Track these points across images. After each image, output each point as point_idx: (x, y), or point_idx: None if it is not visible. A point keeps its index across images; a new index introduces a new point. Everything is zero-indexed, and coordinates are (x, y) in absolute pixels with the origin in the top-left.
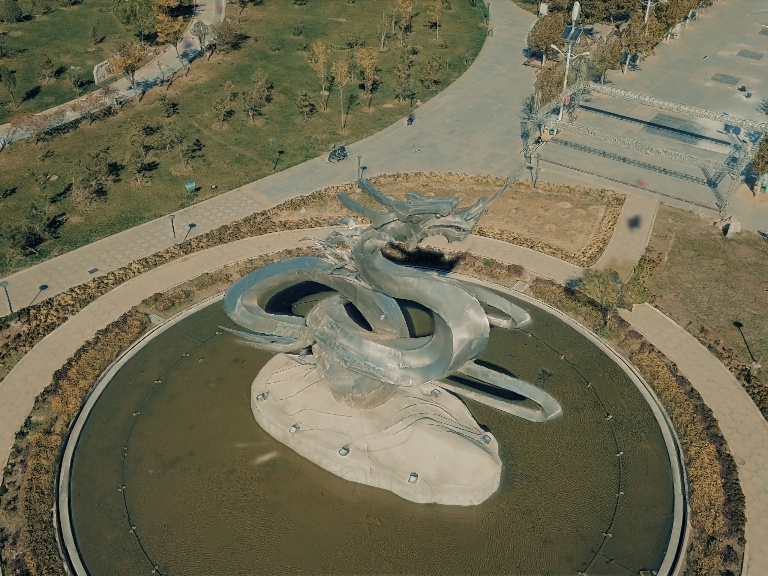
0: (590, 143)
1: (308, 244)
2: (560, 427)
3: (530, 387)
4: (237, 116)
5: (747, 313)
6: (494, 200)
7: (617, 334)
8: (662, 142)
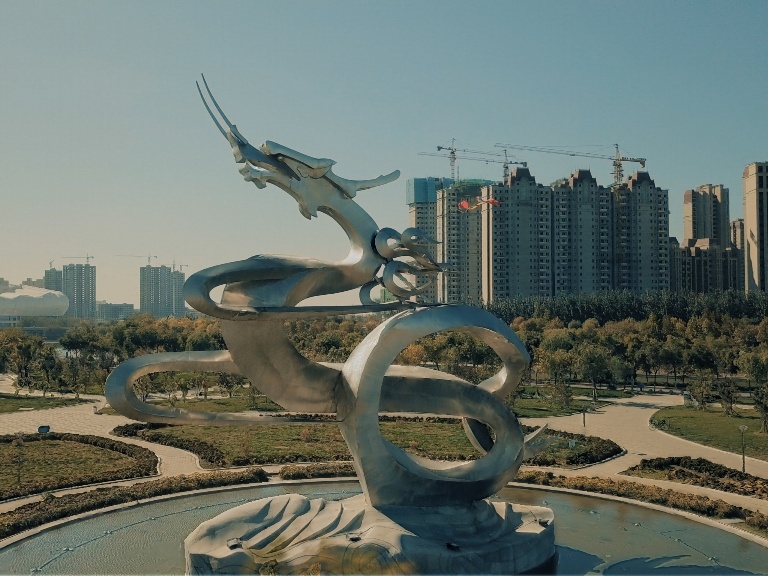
0: None
1: None
2: None
3: None
4: None
5: None
6: None
7: None
8: None
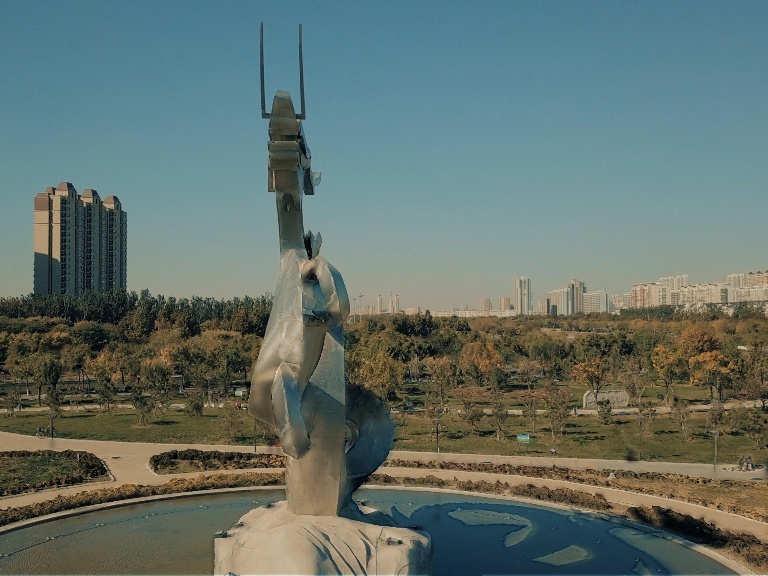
0: None
1: None
2: None
3: None
4: None
5: None
6: None
7: None
8: None
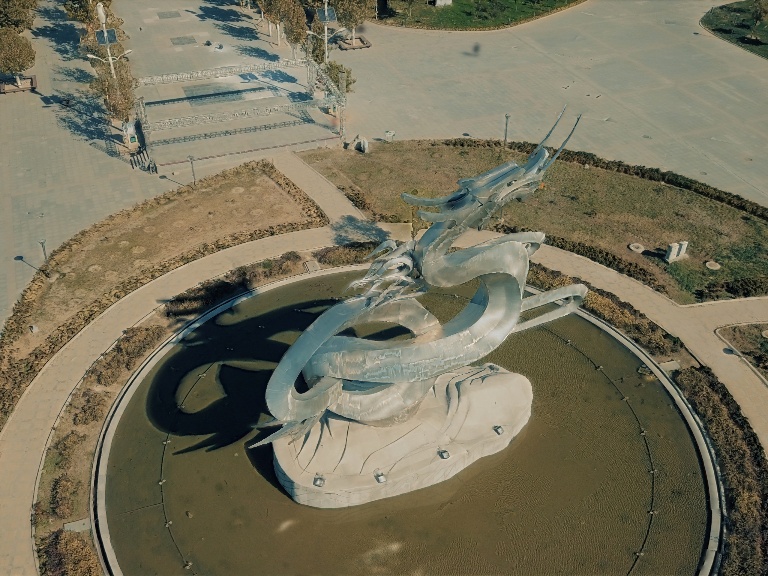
0: (183, 133)
1: (97, 353)
2: None
3: (570, 287)
4: None
5: (449, 193)
6: (182, 217)
7: None
8: (230, 107)
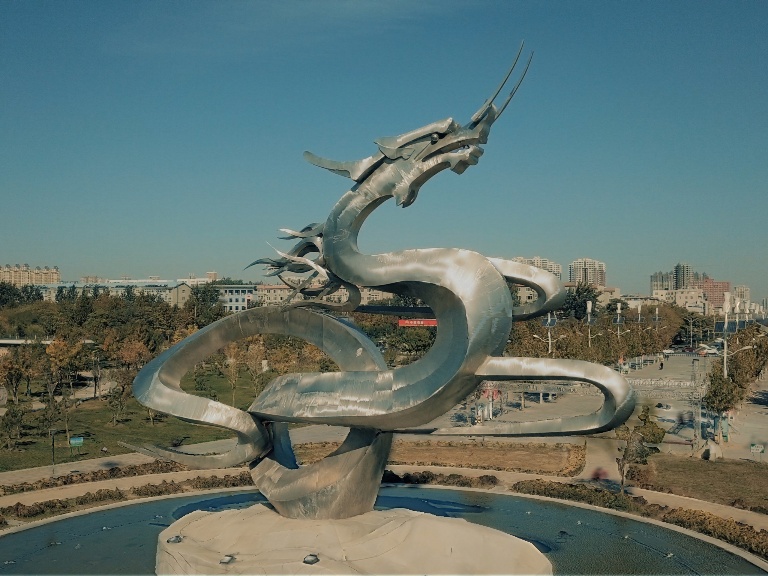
0: None
1: None
2: (609, 568)
3: (583, 363)
4: (134, 421)
5: None
6: (441, 453)
7: (636, 505)
8: None
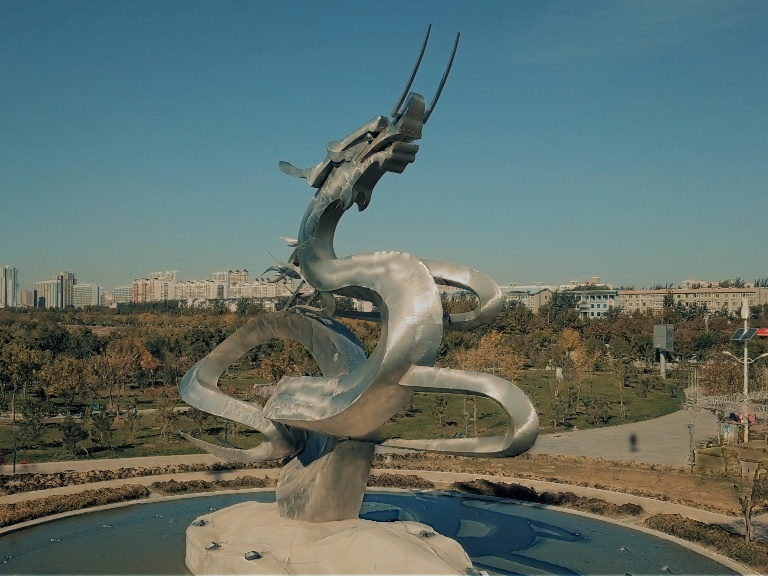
0: None
1: None
2: None
3: (487, 376)
4: None
5: None
6: (631, 475)
7: (765, 559)
8: None
